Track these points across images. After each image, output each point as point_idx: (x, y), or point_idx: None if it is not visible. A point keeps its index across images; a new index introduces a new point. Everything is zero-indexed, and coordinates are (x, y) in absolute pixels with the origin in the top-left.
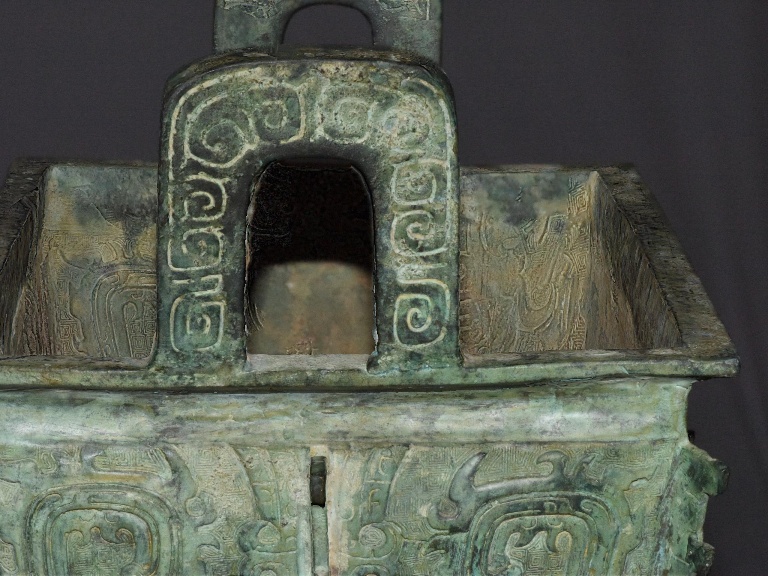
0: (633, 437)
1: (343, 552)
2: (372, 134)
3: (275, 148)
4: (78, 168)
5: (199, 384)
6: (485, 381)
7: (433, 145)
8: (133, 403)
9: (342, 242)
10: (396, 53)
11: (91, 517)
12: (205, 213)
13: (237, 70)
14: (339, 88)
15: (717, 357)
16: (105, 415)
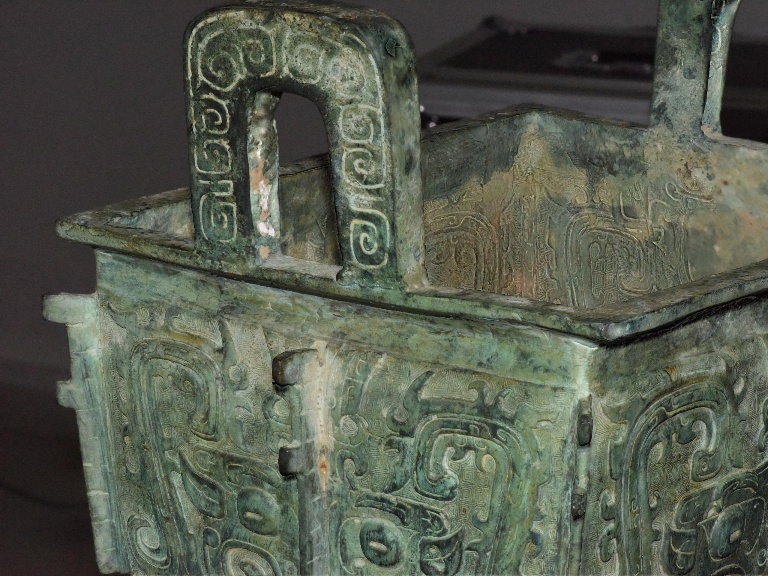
0: (541, 381)
1: (330, 435)
2: (323, 78)
3: (257, 80)
4: (554, 116)
5: (226, 270)
6: (420, 307)
7: (368, 93)
8: (206, 280)
9: (757, 215)
10: (354, 12)
11: (168, 366)
12: (217, 127)
13: (228, 11)
14: (298, 35)
15: (589, 319)
16: (189, 286)
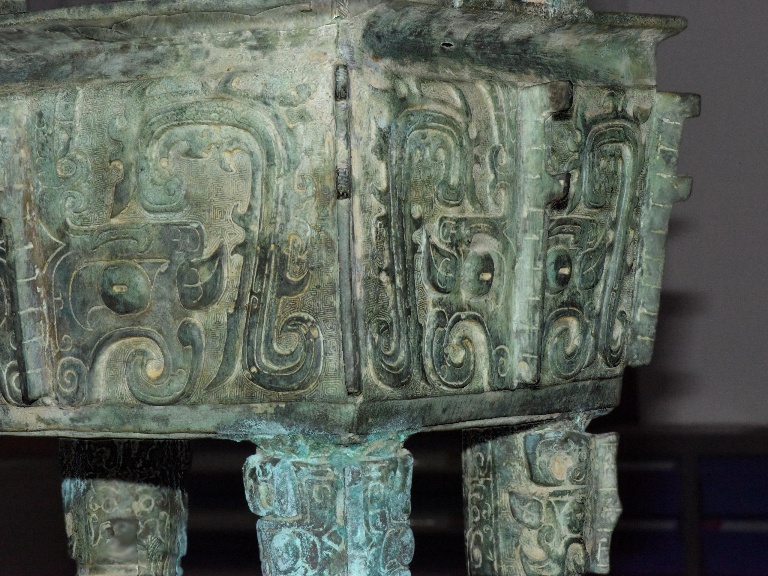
0: None
1: None
2: None
3: None
4: None
5: None
6: None
7: None
8: None
9: None
10: None
11: None
12: None
13: None
14: None
15: None
16: None
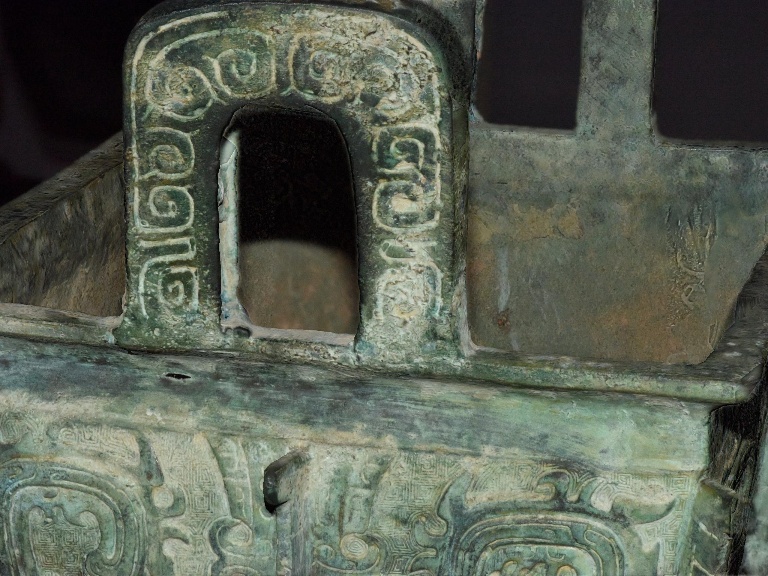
0: None
1: None
2: None
3: None
4: None
5: None
6: None
7: None
8: None
9: None
10: None
11: None
12: None
13: None
14: None
15: None
16: (690, 198)
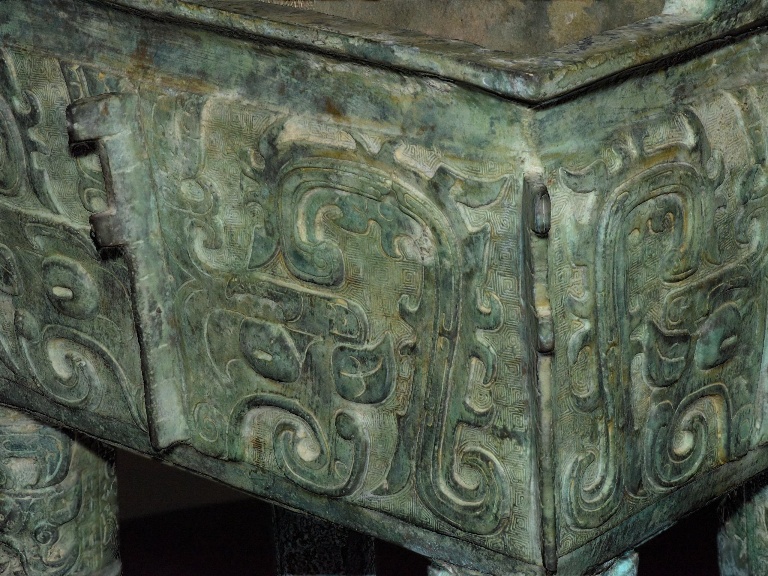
0: None
1: None
2: None
3: None
4: None
5: (738, 25)
6: None
7: None
8: (653, 69)
9: None
10: None
11: (647, 209)
12: None
13: None
14: None
15: None
16: (634, 91)
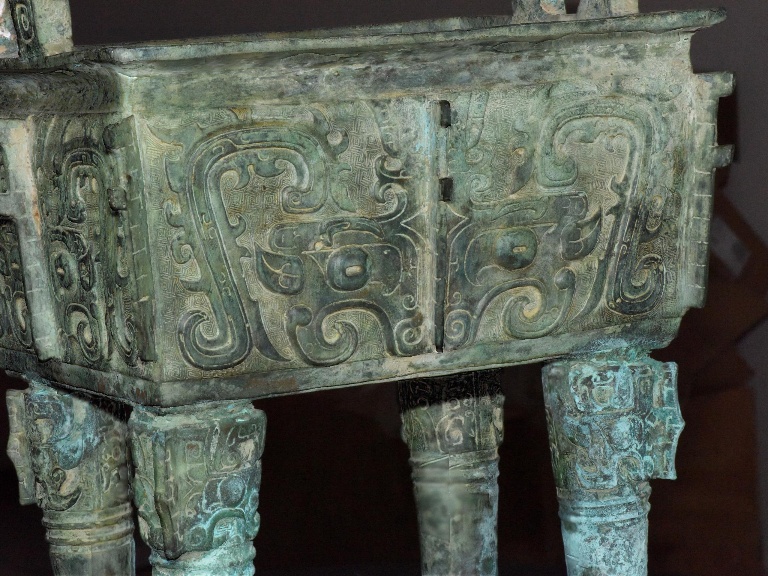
0: None
1: (35, 187)
2: None
3: None
4: None
5: None
6: None
7: None
8: None
9: None
10: None
11: None
12: None
13: None
14: None
15: (109, 47)
16: None
